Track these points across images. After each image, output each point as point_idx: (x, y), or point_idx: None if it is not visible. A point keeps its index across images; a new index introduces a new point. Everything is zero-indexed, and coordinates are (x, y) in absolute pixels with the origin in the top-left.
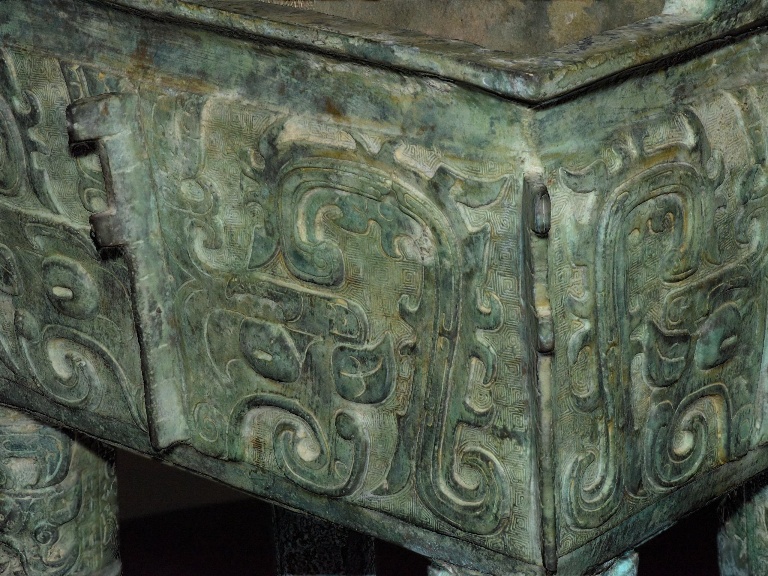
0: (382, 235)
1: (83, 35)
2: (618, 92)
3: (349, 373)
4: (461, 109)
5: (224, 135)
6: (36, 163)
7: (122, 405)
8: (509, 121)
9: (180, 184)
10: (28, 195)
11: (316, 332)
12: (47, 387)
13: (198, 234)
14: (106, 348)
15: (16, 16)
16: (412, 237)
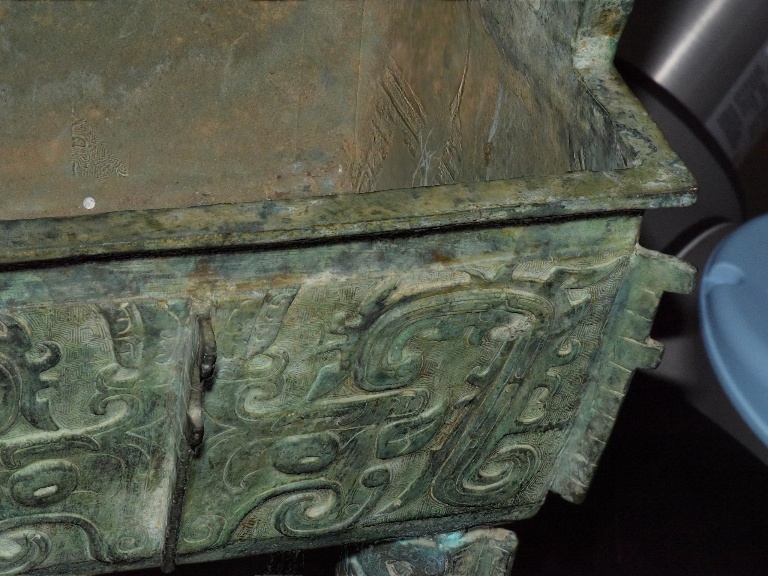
0: (476, 333)
1: (121, 274)
2: None
3: None
4: (578, 222)
5: (312, 310)
6: (38, 397)
7: (77, 552)
8: (627, 219)
9: None
10: (14, 426)
11: (371, 423)
12: None
13: (249, 393)
14: (79, 515)
15: (19, 280)
16: (507, 326)
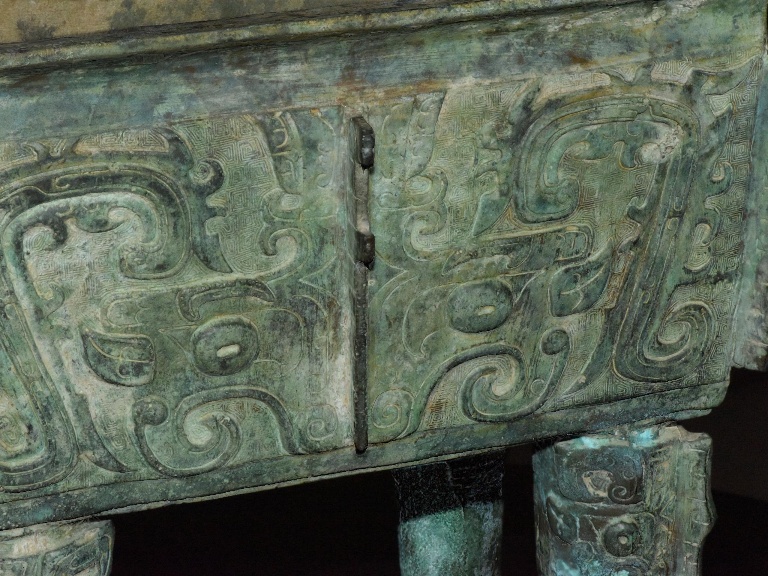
0: (626, 151)
1: (271, 84)
2: None
3: (568, 291)
4: (705, 19)
5: (462, 120)
6: (207, 230)
7: (268, 442)
8: (751, 14)
9: (405, 184)
10: (188, 269)
11: (540, 267)
12: (174, 465)
13: (414, 227)
14: (265, 389)
15: (174, 92)
16: (656, 142)
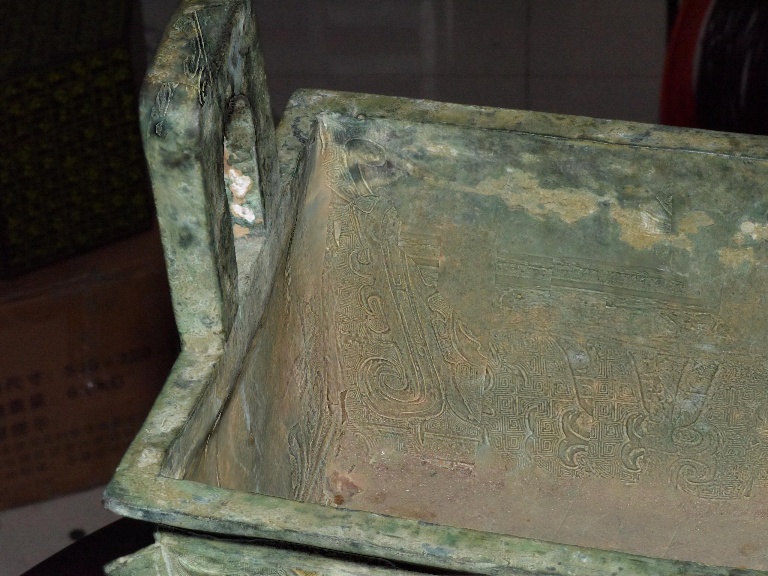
0: None
1: None
2: (298, 201)
3: None
4: None
5: None
6: None
7: None
8: None
9: None
10: None
11: None
12: None
13: None
14: None
15: None
16: None
